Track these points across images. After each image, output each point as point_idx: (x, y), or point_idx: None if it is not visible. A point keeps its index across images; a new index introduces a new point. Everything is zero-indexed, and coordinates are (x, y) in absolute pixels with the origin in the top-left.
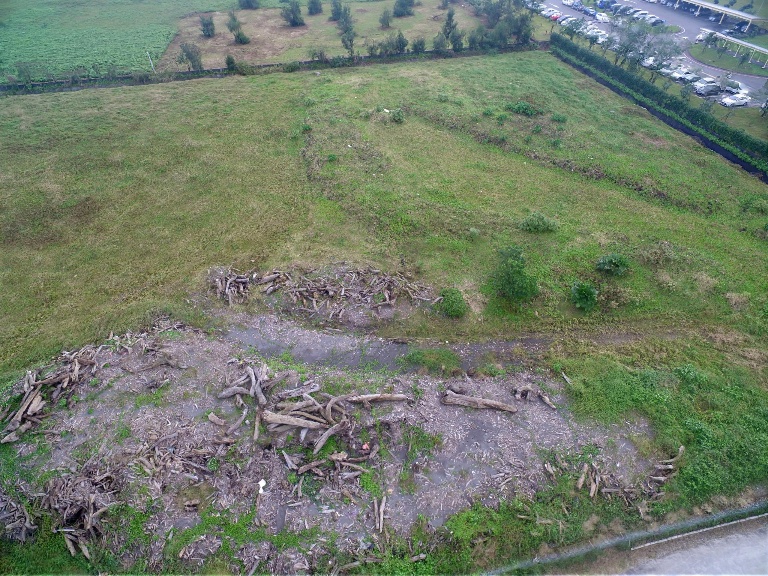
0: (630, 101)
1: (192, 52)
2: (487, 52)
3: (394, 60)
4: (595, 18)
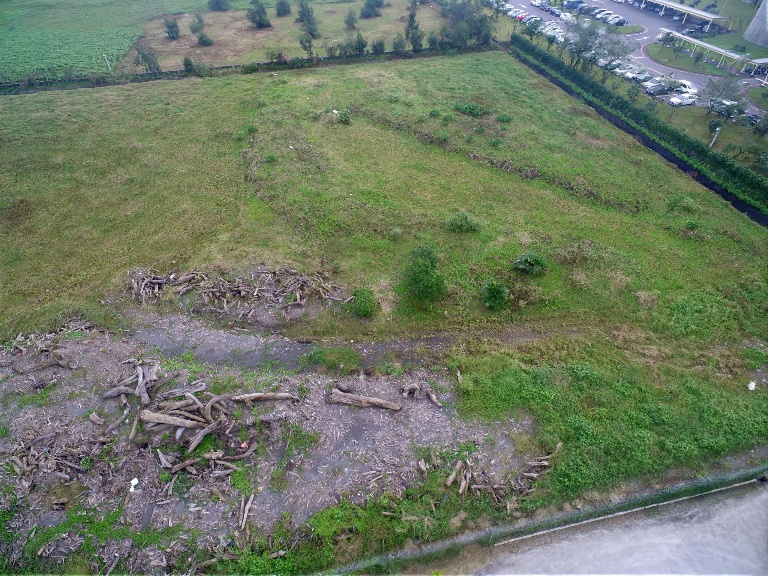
0: (581, 101)
1: (147, 54)
2: (446, 53)
3: (353, 61)
4: (553, 18)
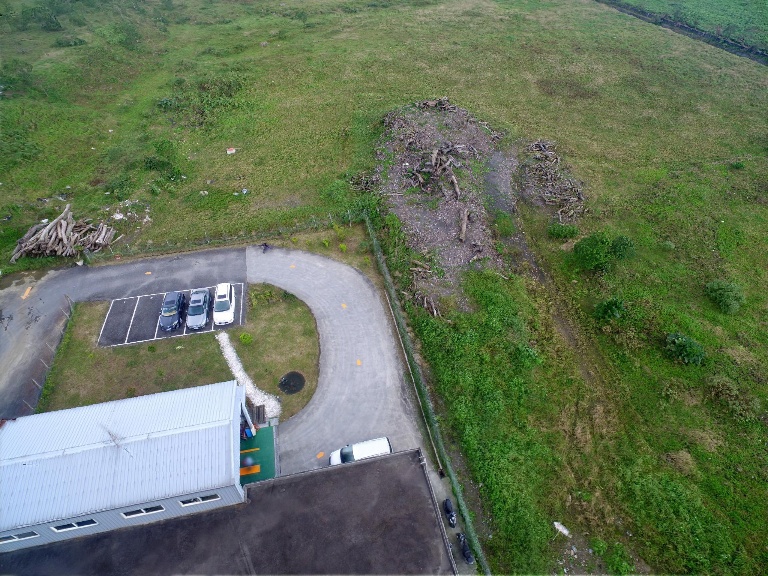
0: None
1: None
2: None
3: None
4: None
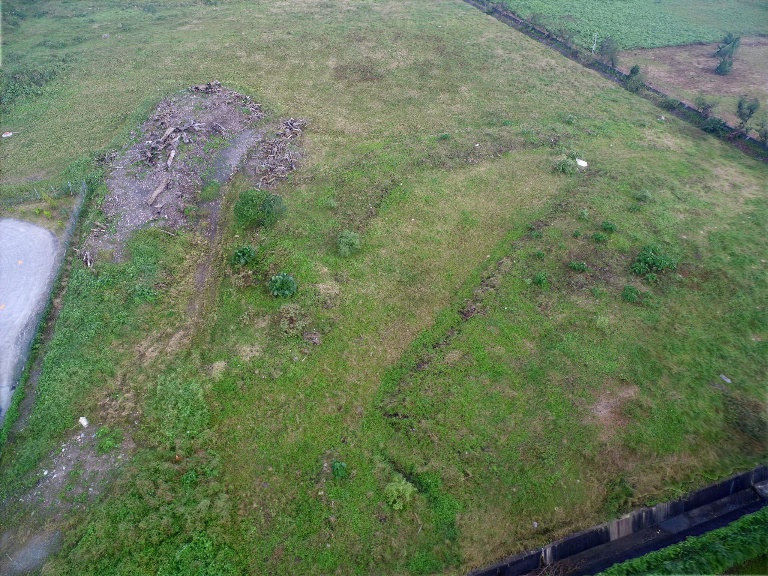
0: None
1: (606, 46)
2: None
3: None
4: None
